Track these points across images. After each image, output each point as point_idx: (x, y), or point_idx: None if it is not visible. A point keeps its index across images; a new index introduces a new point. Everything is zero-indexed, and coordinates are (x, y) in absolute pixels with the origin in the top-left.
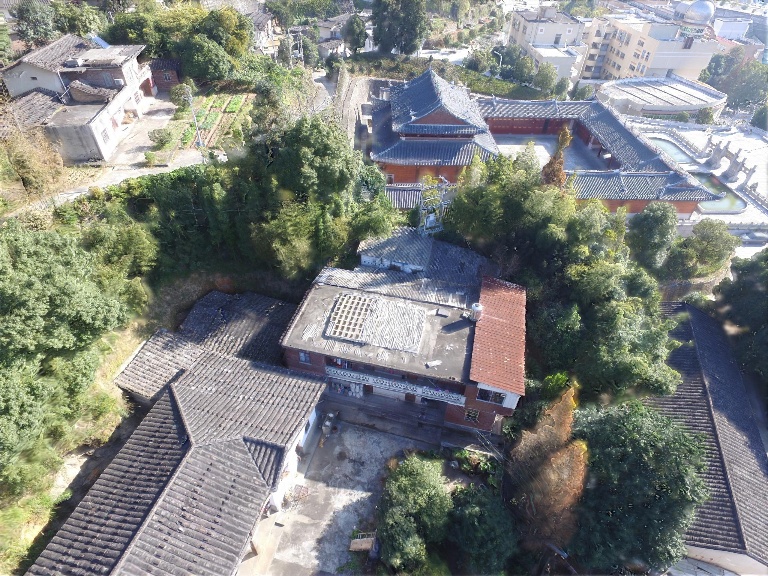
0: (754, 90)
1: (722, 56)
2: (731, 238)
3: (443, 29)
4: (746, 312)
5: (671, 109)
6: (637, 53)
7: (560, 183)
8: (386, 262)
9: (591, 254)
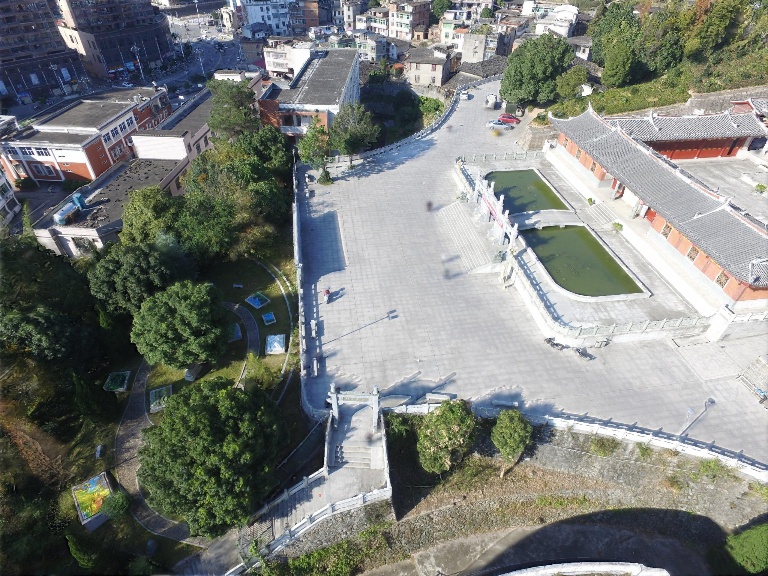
0: None
1: None
2: None
3: None
4: None
5: (523, 575)
6: None
7: None
8: None
9: None
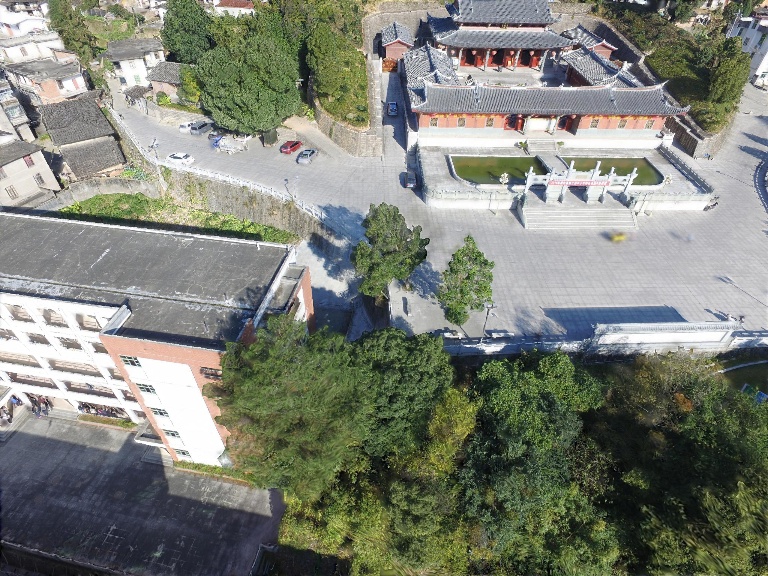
0: None
1: None
2: None
3: None
4: None
5: None
6: None
7: None
8: None
9: None
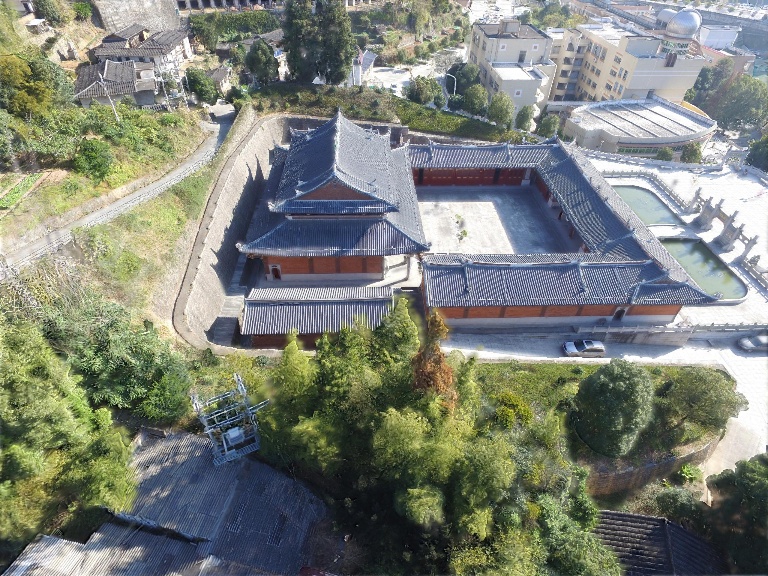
0: (745, 108)
1: (709, 69)
2: (733, 400)
3: (398, 43)
4: (764, 571)
5: (652, 141)
6: (614, 71)
7: (438, 393)
8: (149, 520)
9: (495, 518)
